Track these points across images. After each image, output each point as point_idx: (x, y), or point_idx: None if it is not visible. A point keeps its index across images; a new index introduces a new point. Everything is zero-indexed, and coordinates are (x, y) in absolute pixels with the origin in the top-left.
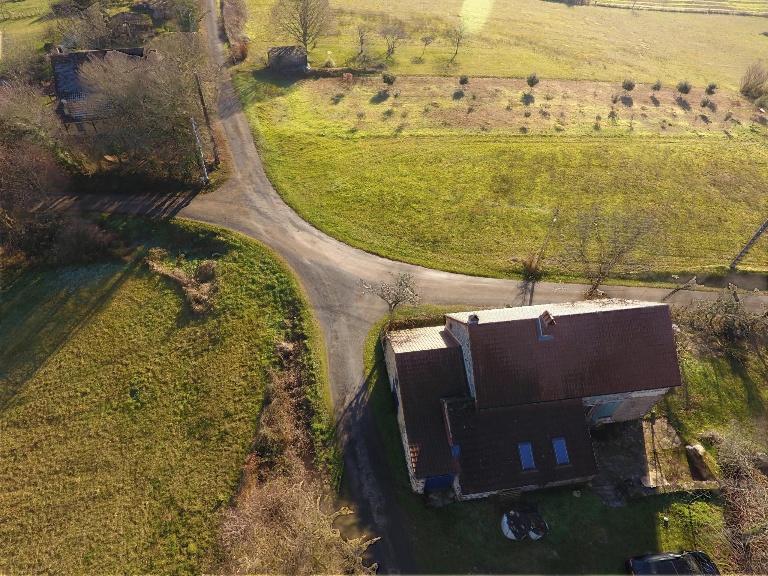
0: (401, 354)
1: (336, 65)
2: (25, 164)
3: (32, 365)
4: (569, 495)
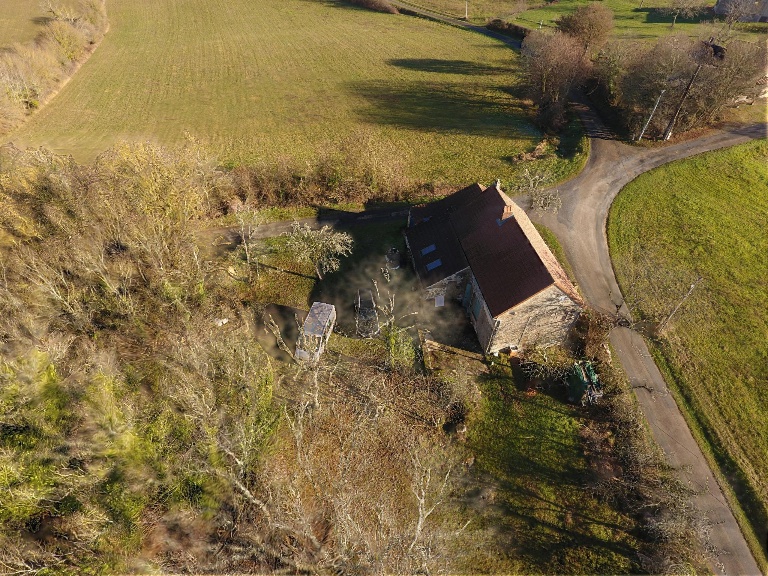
0: (477, 184)
1: None
2: (572, 65)
3: (466, 132)
4: (413, 285)
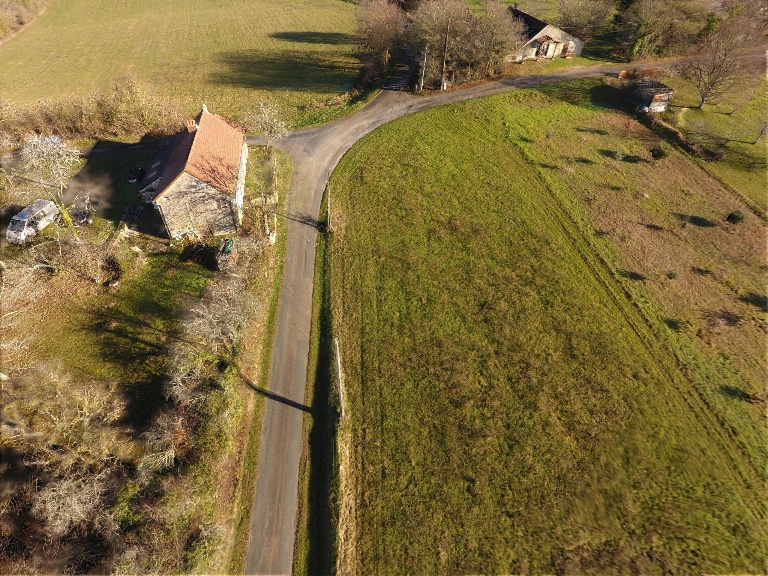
0: None
1: (682, 127)
2: (378, 27)
3: None
4: None
